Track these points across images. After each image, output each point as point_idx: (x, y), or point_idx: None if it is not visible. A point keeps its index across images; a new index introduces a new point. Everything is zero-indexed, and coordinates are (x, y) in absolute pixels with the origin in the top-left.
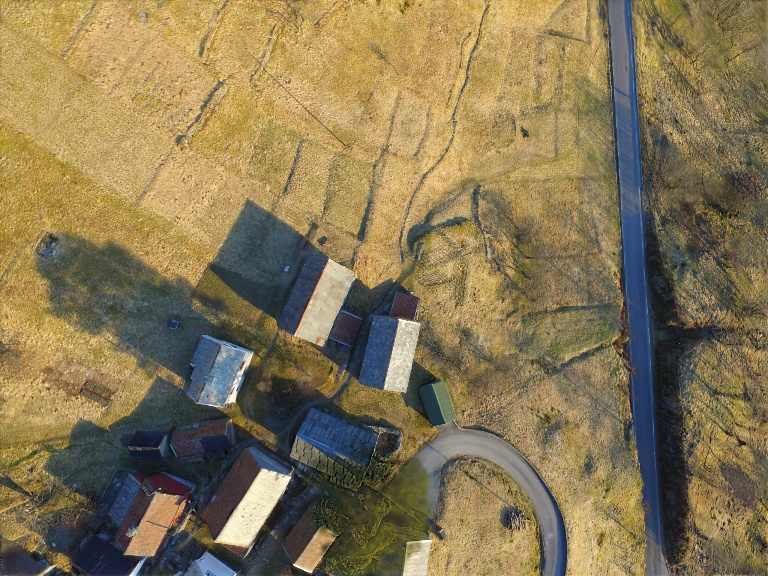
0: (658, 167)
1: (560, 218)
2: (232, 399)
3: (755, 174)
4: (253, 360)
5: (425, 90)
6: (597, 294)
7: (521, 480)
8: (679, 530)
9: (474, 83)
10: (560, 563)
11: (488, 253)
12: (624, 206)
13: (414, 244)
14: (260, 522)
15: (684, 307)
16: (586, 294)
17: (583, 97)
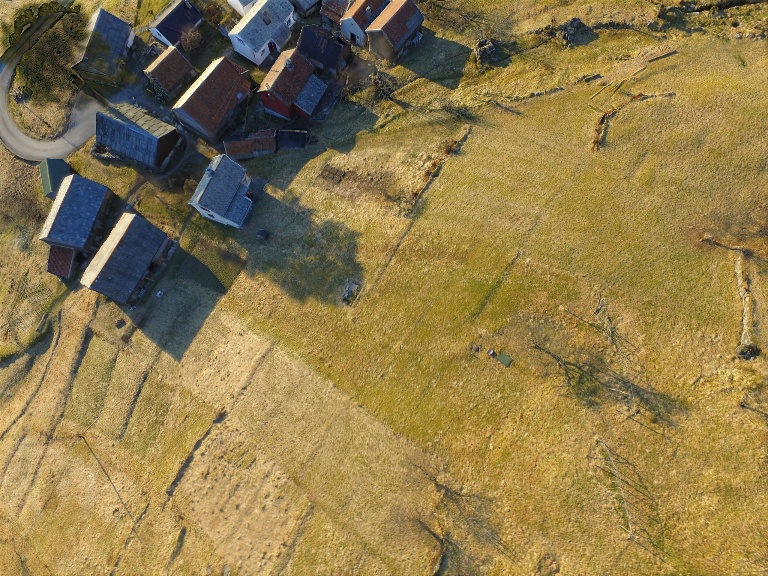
0: None
1: None
2: None
3: None
4: None
5: None
6: None
7: (10, 124)
8: None
9: None
10: (1, 68)
11: None
12: None
13: (46, 330)
14: None
15: None
16: None
17: None
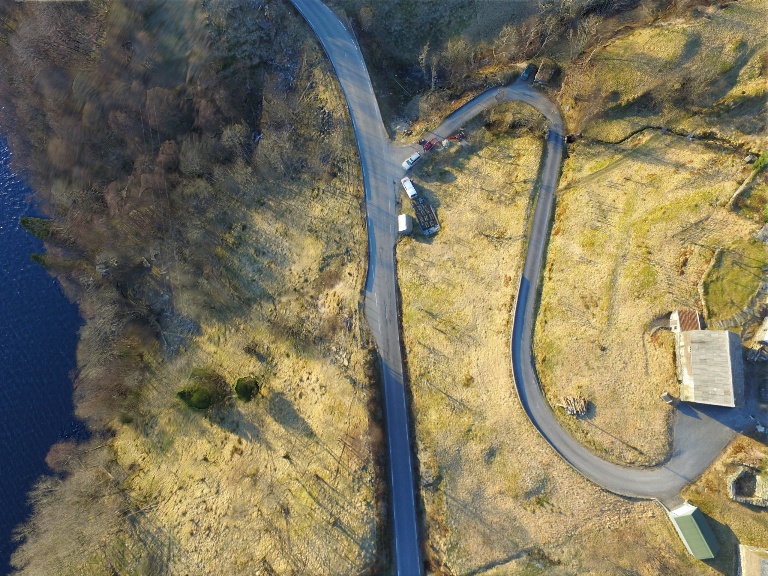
0: None
1: None
2: None
3: None
4: None
5: None
6: None
7: (573, 444)
8: None
9: None
10: (518, 364)
11: None
12: None
13: None
14: None
15: None
16: None
17: None
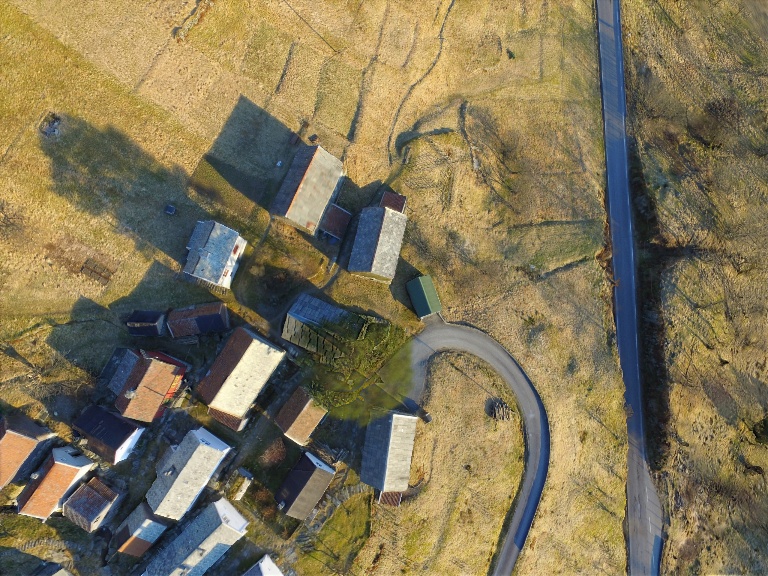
0: (642, 97)
1: (545, 137)
2: (226, 283)
3: (738, 111)
4: (247, 249)
5: (413, 5)
6: (581, 210)
7: (505, 374)
8: (661, 436)
9: (461, 4)
10: (543, 455)
11: (474, 163)
12: (608, 131)
13: (402, 148)
14: (253, 395)
15: (666, 224)
16: (570, 210)
17: (568, 25)
